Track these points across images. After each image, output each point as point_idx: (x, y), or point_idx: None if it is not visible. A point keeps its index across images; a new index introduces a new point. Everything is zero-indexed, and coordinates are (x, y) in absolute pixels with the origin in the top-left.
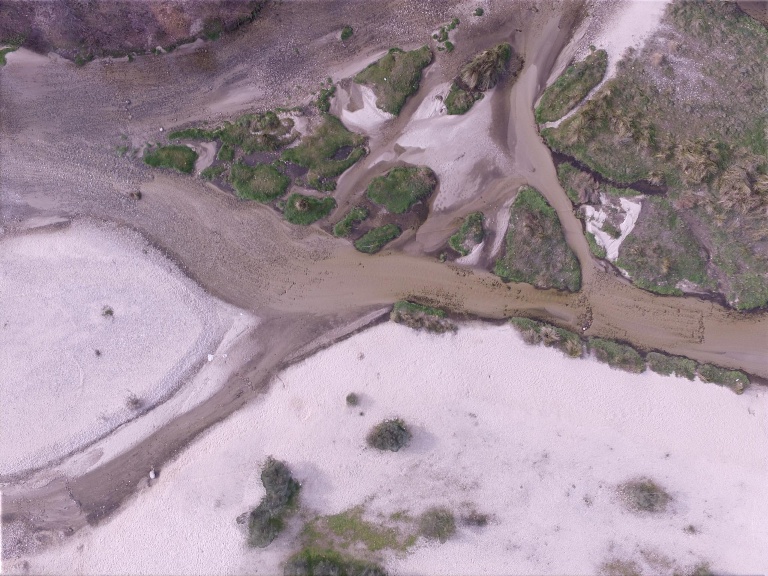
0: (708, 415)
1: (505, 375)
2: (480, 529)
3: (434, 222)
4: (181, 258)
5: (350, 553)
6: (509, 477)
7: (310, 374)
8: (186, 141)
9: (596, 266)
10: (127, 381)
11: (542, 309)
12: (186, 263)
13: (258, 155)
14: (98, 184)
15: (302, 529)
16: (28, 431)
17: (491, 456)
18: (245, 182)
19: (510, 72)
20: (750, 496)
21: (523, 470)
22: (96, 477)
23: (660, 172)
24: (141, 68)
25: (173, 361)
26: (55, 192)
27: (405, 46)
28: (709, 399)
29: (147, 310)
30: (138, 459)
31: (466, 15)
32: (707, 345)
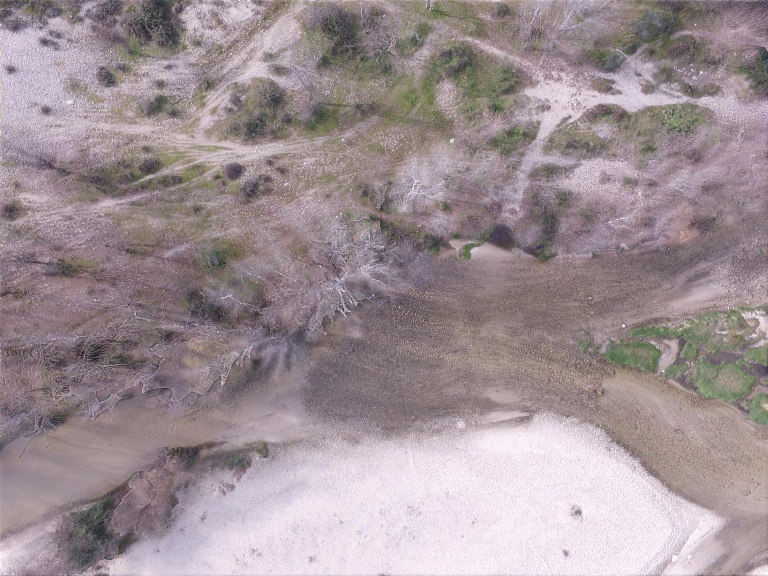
0: None
1: None
2: None
3: None
4: (644, 456)
5: None
6: None
7: None
8: (649, 338)
9: None
10: None
11: None
12: (649, 461)
13: (722, 354)
14: (559, 379)
15: None
16: None
17: None
18: (710, 381)
19: None
20: None
21: None
22: None
23: None
24: (603, 264)
25: (642, 563)
26: (516, 386)
27: None
28: None
29: (616, 510)
30: None
31: None
32: None
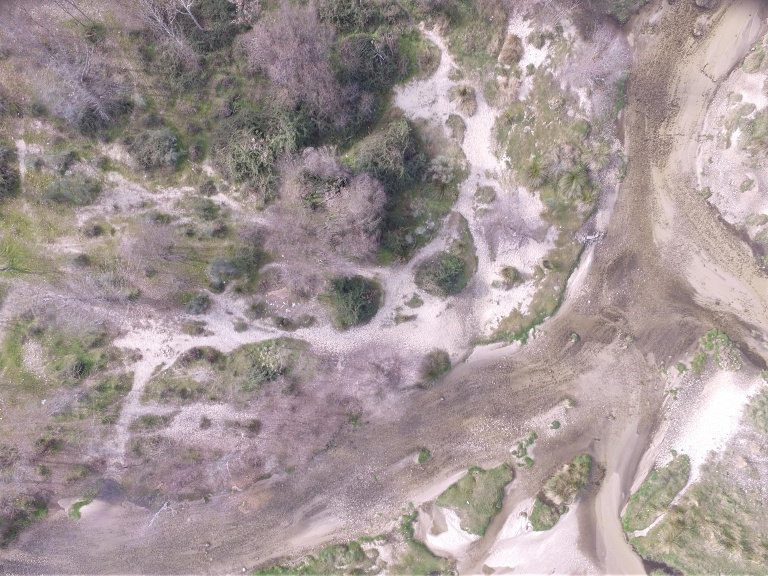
0: None
1: None
2: None
3: None
4: None
5: None
6: None
7: None
8: None
9: None
10: None
11: None
12: None
13: None
14: None
15: None
16: None
17: None
18: None
19: (593, 482)
20: None
21: None
22: None
23: None
24: (218, 508)
25: None
26: None
27: (484, 464)
28: None
29: None
30: None
31: (543, 428)
32: None
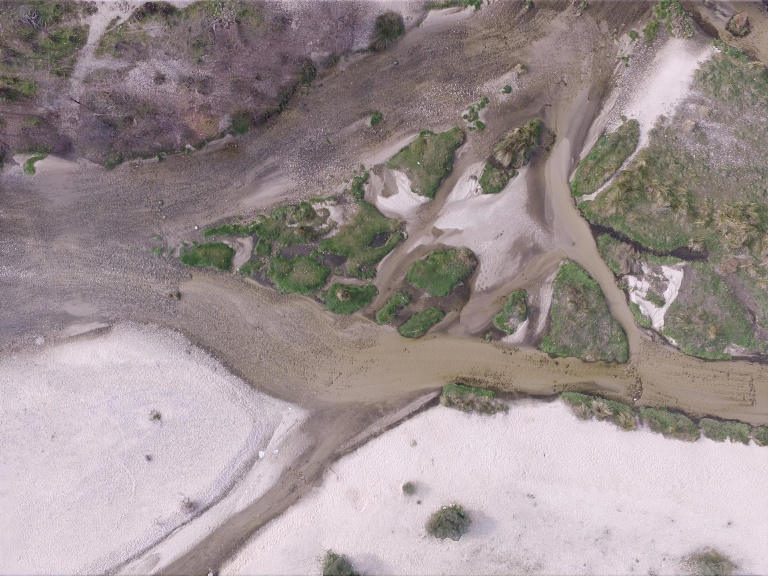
0: (766, 479)
1: (560, 453)
2: None
3: (477, 302)
4: (225, 356)
5: None
6: (572, 556)
7: (363, 464)
8: (222, 238)
9: (642, 336)
10: (179, 485)
11: (591, 382)
12: (230, 361)
13: (295, 247)
14: (136, 287)
15: None
16: (83, 543)
17: (552, 536)
18: (284, 275)
19: (543, 147)
20: None
21: (585, 548)
22: None
23: (701, 239)
24: (172, 167)
25: (224, 461)
26: (93, 298)
27: (436, 128)
28: (766, 462)
29: (195, 412)
30: (195, 562)
31: (495, 93)
32: (759, 407)
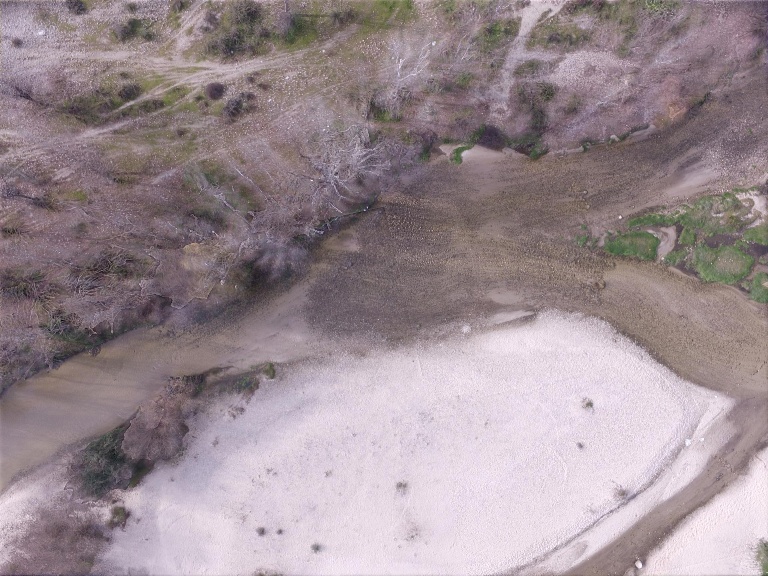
0: None
1: None
2: None
3: None
4: (650, 344)
5: None
6: None
7: None
8: (646, 227)
9: None
10: (611, 472)
11: None
12: (656, 349)
13: (720, 237)
14: (560, 275)
15: None
16: (516, 530)
17: None
18: (710, 264)
19: None
20: None
21: None
22: (581, 571)
23: None
24: (595, 158)
25: (656, 449)
26: (518, 286)
27: None
28: None
29: (626, 399)
30: (622, 550)
31: None
32: None
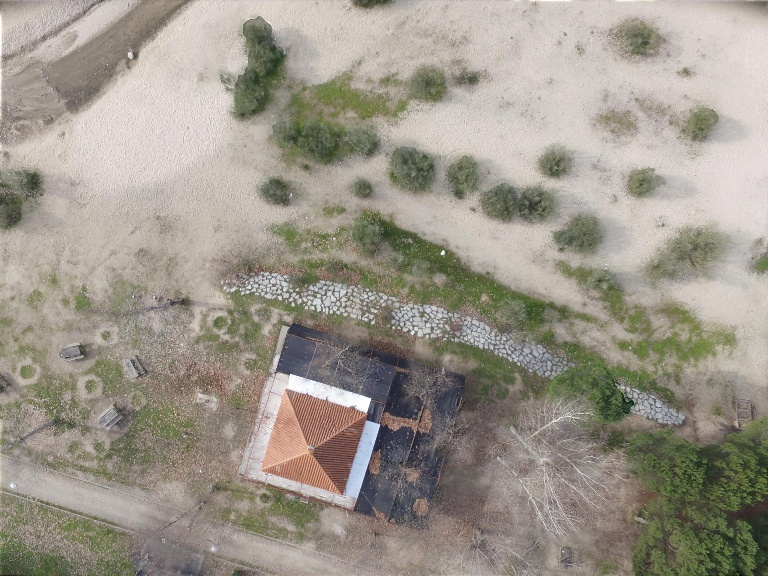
0: None
1: None
2: (472, 87)
3: None
4: None
5: (340, 122)
6: (499, 28)
7: None
8: None
9: None
10: None
11: None
12: None
13: None
14: None
15: (289, 101)
16: None
17: (479, 7)
18: None
19: None
20: (744, 31)
21: (513, 20)
22: (72, 62)
23: None
24: None
25: None
26: None
27: None
28: None
29: None
30: (115, 41)
31: None
32: None
